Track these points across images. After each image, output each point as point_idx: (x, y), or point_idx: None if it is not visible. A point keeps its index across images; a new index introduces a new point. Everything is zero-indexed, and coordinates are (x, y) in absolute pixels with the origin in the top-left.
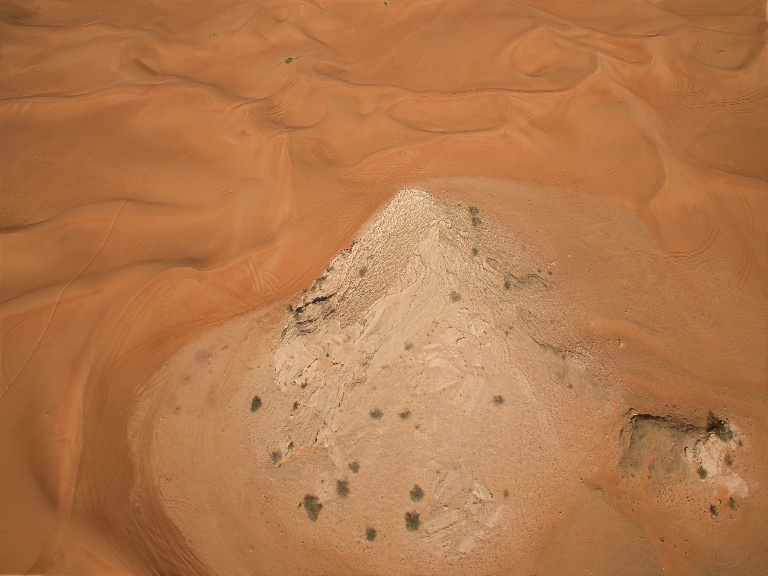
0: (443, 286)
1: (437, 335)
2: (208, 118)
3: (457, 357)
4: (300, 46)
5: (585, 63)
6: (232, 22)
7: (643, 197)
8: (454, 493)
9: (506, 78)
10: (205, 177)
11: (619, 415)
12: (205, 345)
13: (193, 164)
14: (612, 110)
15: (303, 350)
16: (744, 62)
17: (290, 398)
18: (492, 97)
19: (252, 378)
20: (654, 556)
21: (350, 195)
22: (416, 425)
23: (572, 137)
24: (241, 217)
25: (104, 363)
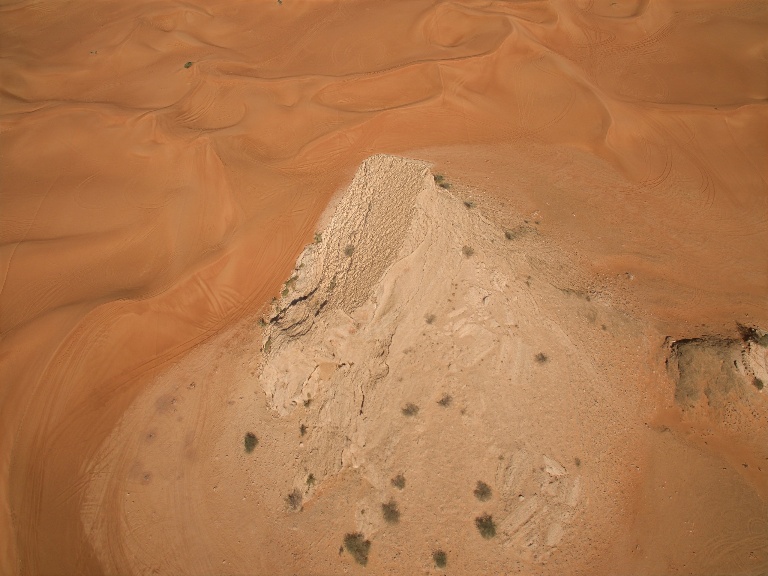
0: (453, 241)
1: (460, 298)
2: (106, 135)
3: (487, 319)
4: (196, 52)
5: (499, 27)
6: (110, 38)
7: (596, 137)
8: (525, 478)
9: (427, 51)
10: (118, 198)
11: (658, 347)
12: (165, 389)
13: (99, 187)
14: (538, 65)
15: (299, 358)
16: (637, 10)
17: (293, 423)
18: (420, 69)
19: (237, 413)
20: (745, 485)
21: (298, 187)
22: (461, 410)
23: (508, 96)
24: (175, 232)
25: (30, 444)
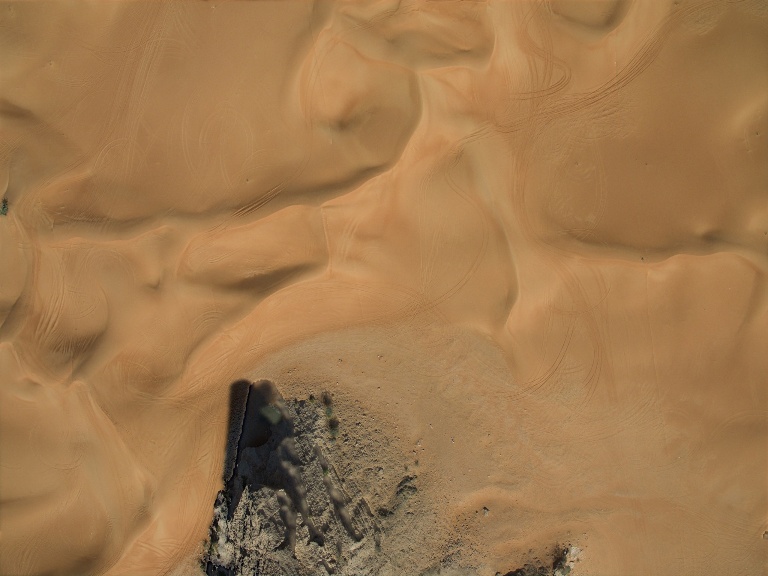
0: None
1: None
2: None
3: None
4: None
5: (404, 98)
6: None
7: (496, 320)
8: None
9: (307, 152)
10: (30, 457)
11: None
12: None
13: (4, 440)
14: (451, 179)
15: None
16: (617, 6)
17: None
18: (299, 213)
19: None
20: None
21: (195, 422)
22: None
23: (410, 237)
24: (101, 497)
25: None
